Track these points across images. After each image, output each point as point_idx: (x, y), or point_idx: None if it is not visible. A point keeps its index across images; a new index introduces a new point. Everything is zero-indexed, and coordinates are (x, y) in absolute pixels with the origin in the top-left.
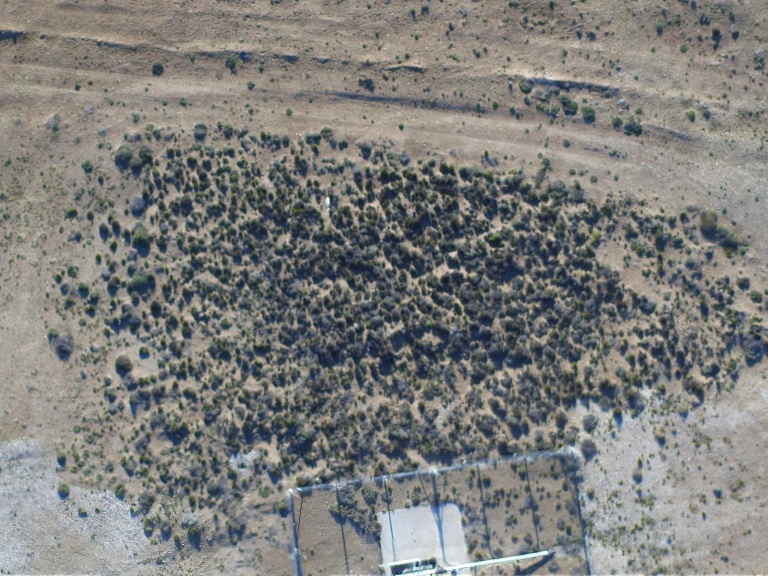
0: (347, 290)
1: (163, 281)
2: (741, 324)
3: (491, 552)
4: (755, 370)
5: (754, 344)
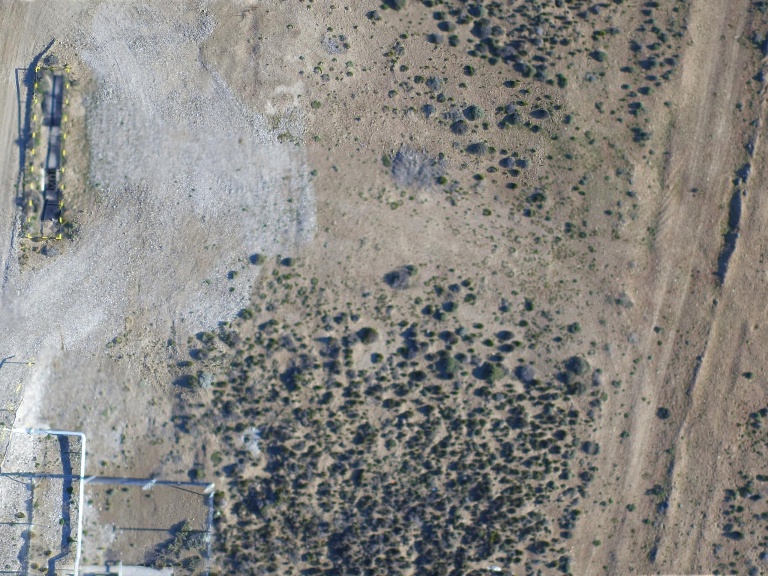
0: (403, 575)
1: (446, 387)
2: None
3: None
4: None
5: None
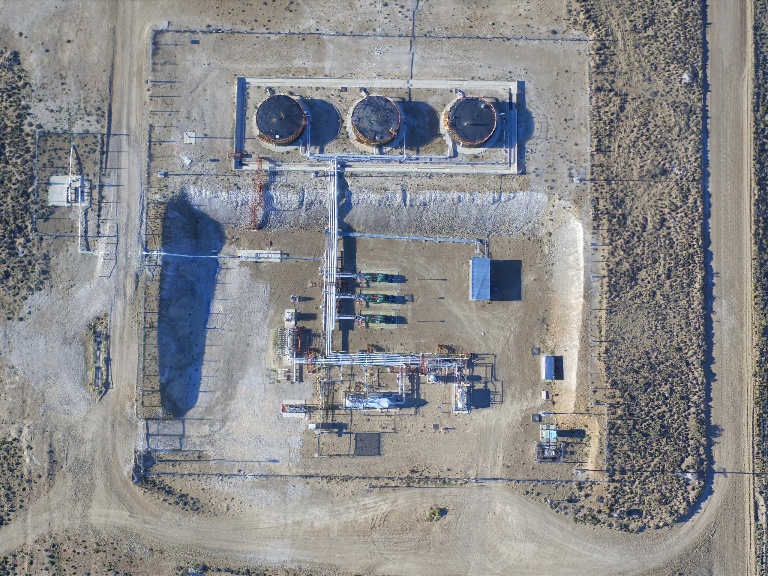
0: None
1: None
2: (5, 64)
3: (69, 167)
4: (23, 63)
5: (13, 61)
